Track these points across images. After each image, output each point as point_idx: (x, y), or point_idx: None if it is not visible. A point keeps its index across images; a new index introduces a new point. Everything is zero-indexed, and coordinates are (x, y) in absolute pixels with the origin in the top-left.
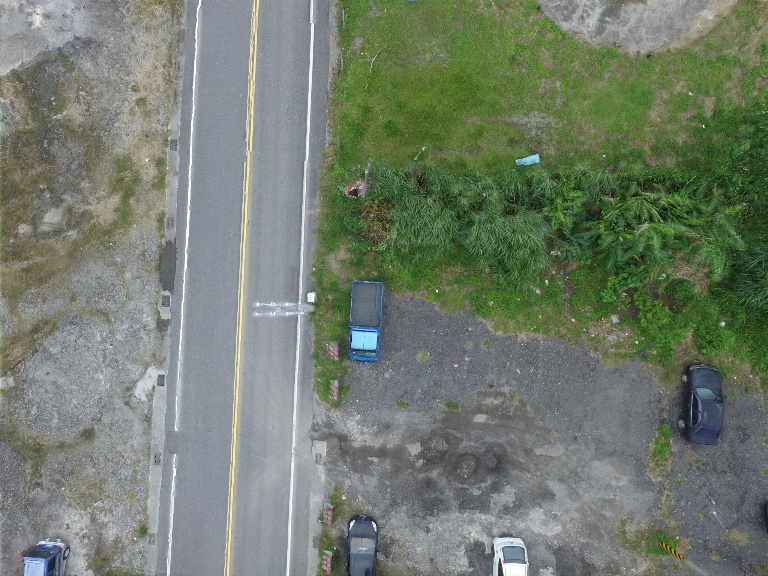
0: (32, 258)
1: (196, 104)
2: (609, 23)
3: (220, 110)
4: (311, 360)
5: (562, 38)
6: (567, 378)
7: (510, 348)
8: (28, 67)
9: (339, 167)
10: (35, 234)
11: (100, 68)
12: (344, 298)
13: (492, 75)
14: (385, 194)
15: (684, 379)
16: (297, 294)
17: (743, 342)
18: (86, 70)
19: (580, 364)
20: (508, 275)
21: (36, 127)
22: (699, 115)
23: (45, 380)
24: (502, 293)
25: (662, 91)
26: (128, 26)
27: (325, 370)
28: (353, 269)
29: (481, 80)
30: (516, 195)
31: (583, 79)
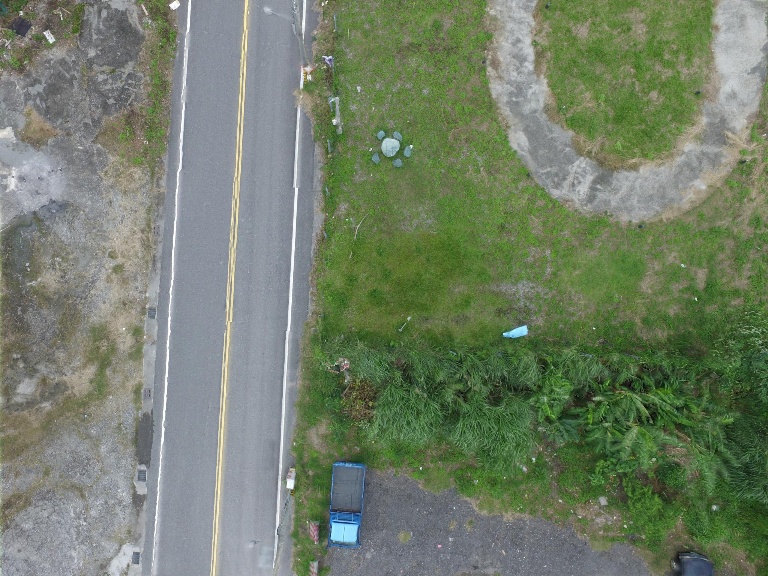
0: (4, 430)
1: (175, 271)
2: (600, 191)
3: (200, 277)
4: (291, 538)
5: (552, 206)
6: (553, 560)
7: (495, 528)
8: (2, 231)
9: (320, 352)
10: (7, 405)
11: (77, 233)
12: (325, 475)
13: (480, 243)
14: (368, 378)
15: (673, 565)
16: (277, 469)
17: (734, 527)
18: (62, 235)
19: (567, 546)
20: (493, 461)
21: (10, 294)
22: (691, 287)
23: (16, 558)
24: (488, 472)
25: (654, 262)
26: (106, 189)
27: (305, 549)
28: (335, 444)
29: (469, 248)
30: (502, 380)
31: (573, 249)
